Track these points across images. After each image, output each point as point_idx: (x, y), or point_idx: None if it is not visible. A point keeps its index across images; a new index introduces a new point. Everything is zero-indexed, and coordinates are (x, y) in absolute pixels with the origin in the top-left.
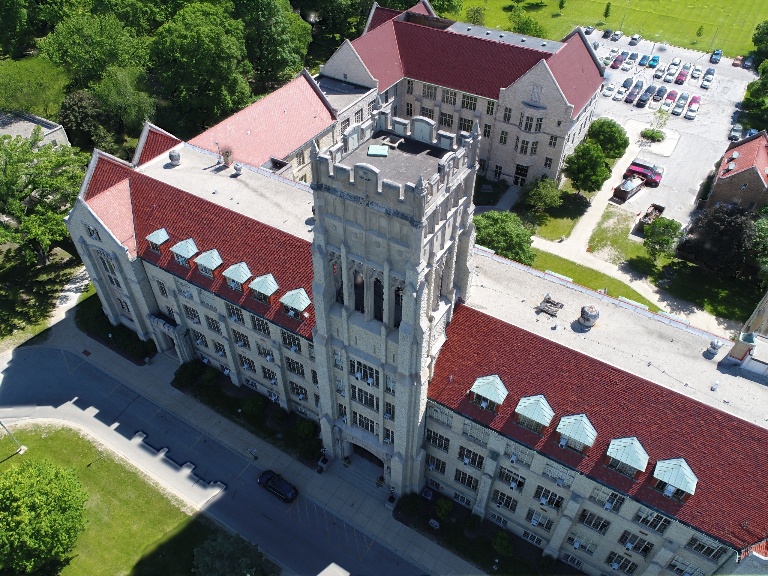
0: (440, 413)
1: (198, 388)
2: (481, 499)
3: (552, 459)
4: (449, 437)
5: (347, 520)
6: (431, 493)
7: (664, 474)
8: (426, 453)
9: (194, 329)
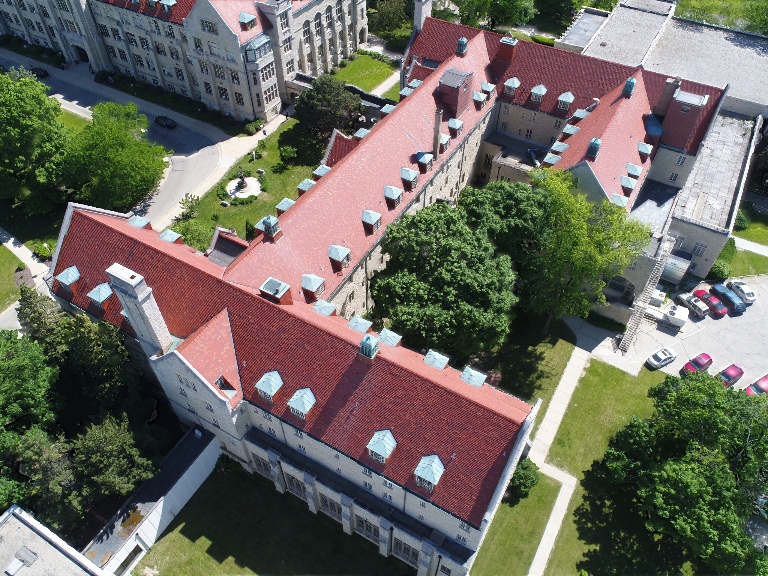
0: (96, 7)
1: (9, 45)
2: (129, 62)
3: (130, 10)
4: (105, 23)
5: (70, 82)
6: (114, 71)
7: (162, 0)
8: (106, 45)
9: (3, 10)
